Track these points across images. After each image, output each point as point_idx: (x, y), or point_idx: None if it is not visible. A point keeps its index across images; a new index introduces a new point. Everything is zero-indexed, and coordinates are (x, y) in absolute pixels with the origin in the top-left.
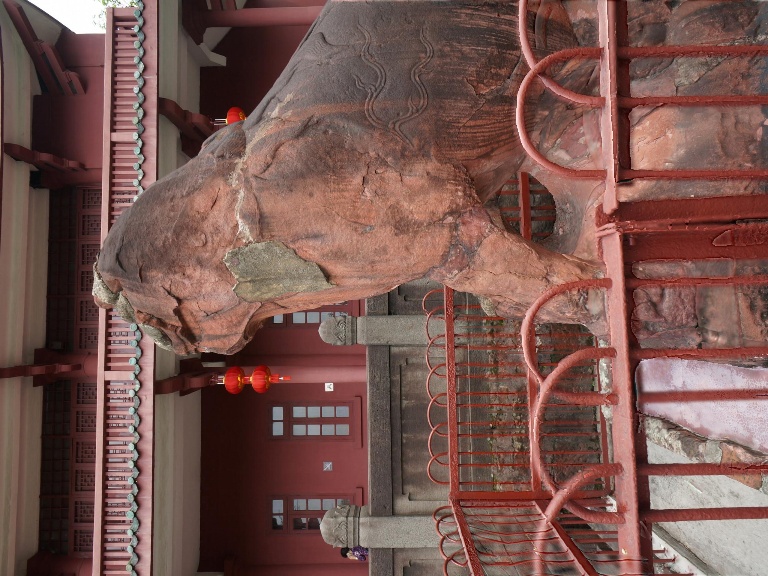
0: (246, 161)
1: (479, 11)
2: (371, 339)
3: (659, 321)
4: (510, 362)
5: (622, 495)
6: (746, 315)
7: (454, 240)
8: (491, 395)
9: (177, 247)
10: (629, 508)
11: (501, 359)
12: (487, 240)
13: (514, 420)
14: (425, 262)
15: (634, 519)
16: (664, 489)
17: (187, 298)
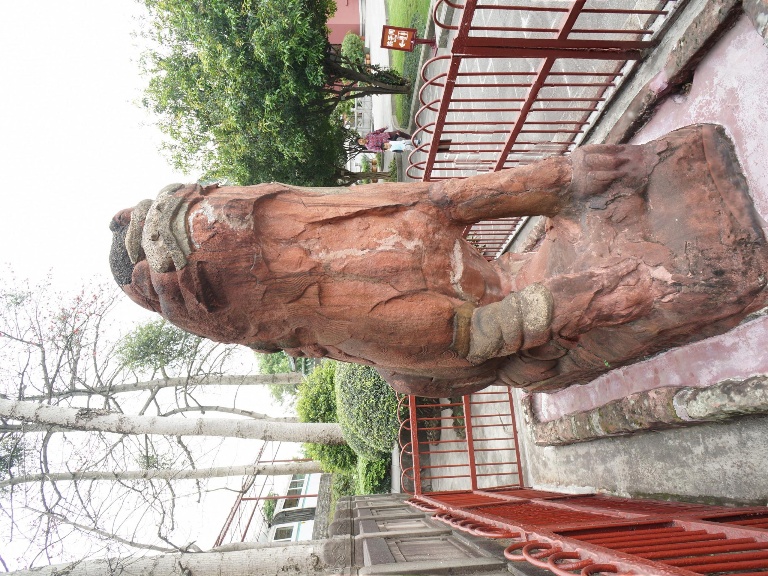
0: None
1: None
2: None
3: None
4: None
5: None
6: None
7: None
8: None
9: None
10: None
11: None
12: None
13: None
14: None
15: None
16: None
17: None
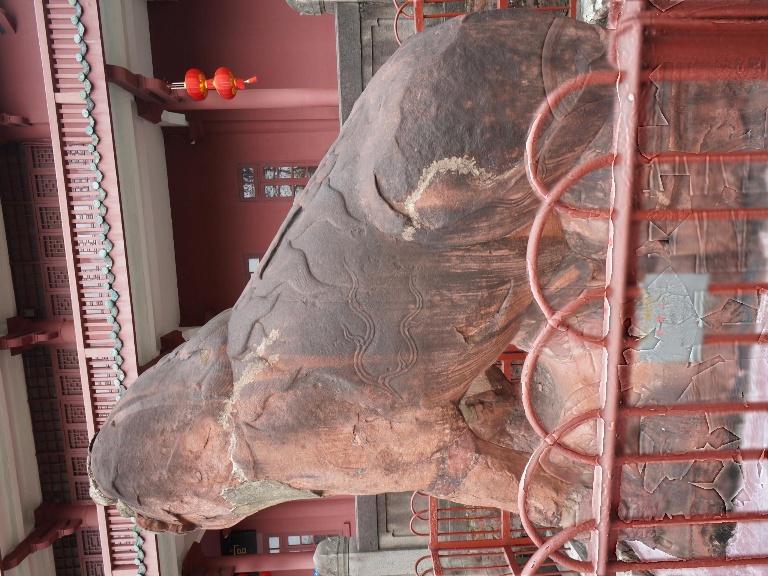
0: (235, 404)
1: (470, 251)
2: None
3: None
4: None
5: None
6: (697, 538)
7: (441, 471)
8: None
9: (173, 482)
10: None
11: None
12: (472, 473)
13: None
14: None
15: None
16: None
17: (186, 513)
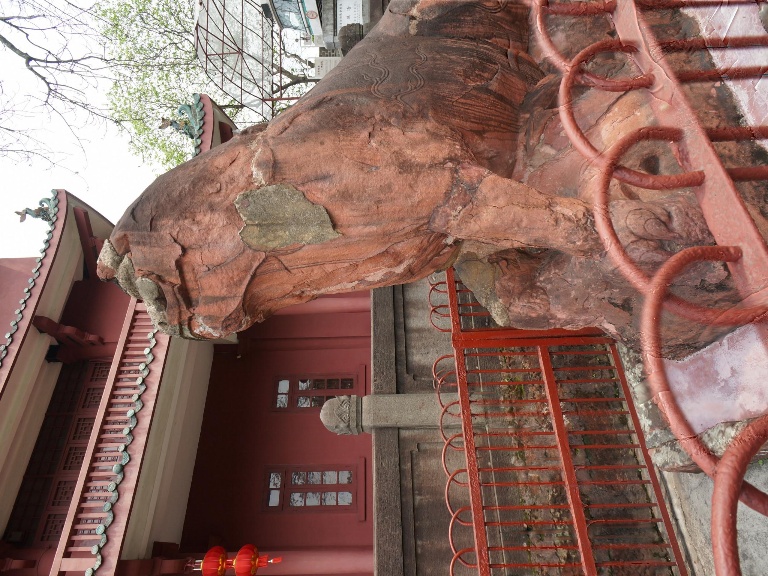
0: (266, 132)
1: (461, 41)
2: (378, 420)
3: (674, 237)
4: (537, 444)
5: (644, 64)
6: (760, 221)
7: (455, 181)
8: (520, 486)
9: (192, 195)
10: (655, 67)
11: (526, 441)
12: (487, 178)
13: (553, 518)
14: (429, 199)
15: (664, 77)
16: (762, 558)
17: (192, 247)
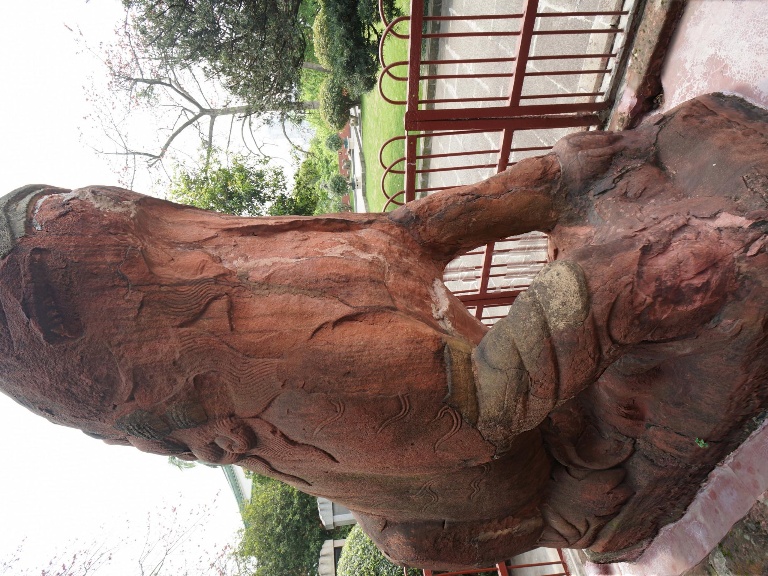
0: None
1: None
2: None
3: None
4: None
5: None
6: None
7: None
8: None
9: None
10: None
11: None
12: None
13: None
14: None
15: None
16: None
17: None
